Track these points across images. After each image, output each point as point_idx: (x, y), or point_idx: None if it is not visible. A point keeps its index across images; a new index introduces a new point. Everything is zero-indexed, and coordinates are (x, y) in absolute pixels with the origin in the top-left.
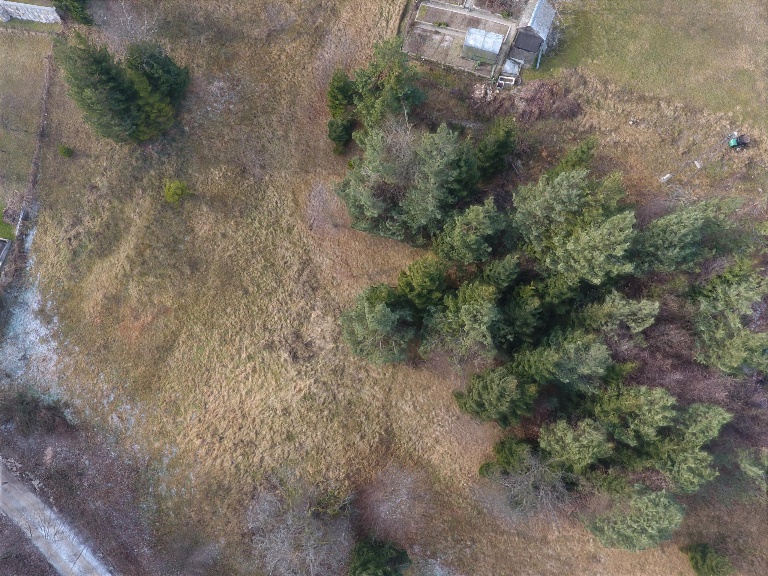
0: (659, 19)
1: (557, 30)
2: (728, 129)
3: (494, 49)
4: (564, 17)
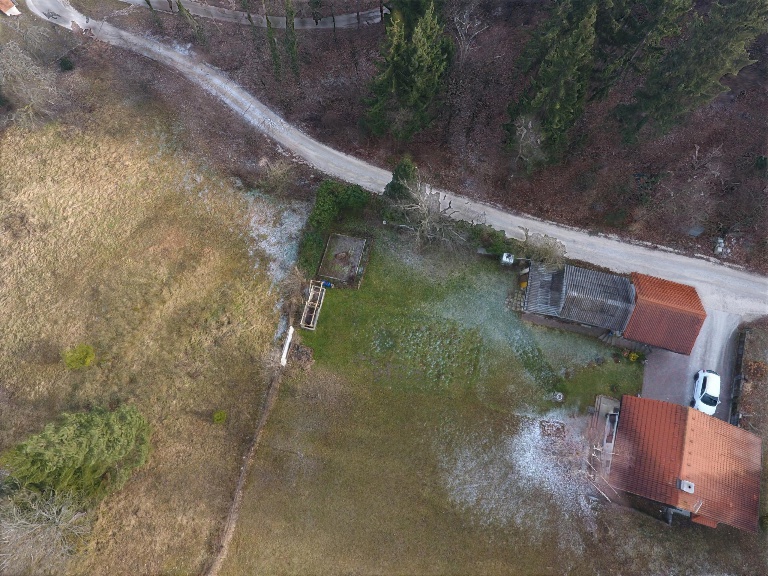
0: None
1: None
2: None
3: None
4: None
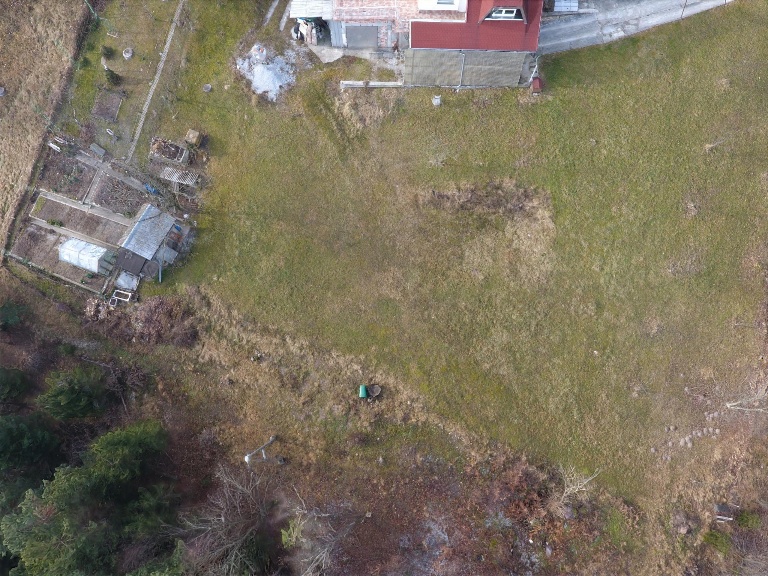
0: (302, 229)
1: (193, 232)
2: (360, 374)
3: (91, 267)
4: (202, 217)
